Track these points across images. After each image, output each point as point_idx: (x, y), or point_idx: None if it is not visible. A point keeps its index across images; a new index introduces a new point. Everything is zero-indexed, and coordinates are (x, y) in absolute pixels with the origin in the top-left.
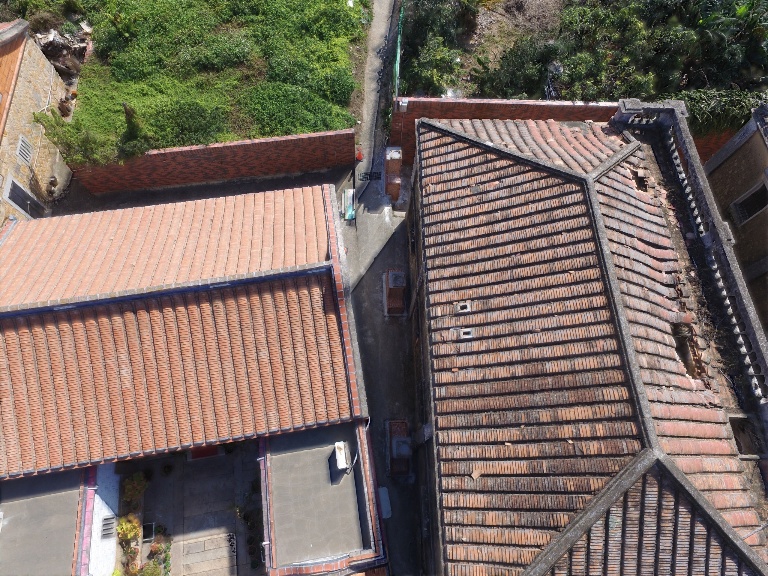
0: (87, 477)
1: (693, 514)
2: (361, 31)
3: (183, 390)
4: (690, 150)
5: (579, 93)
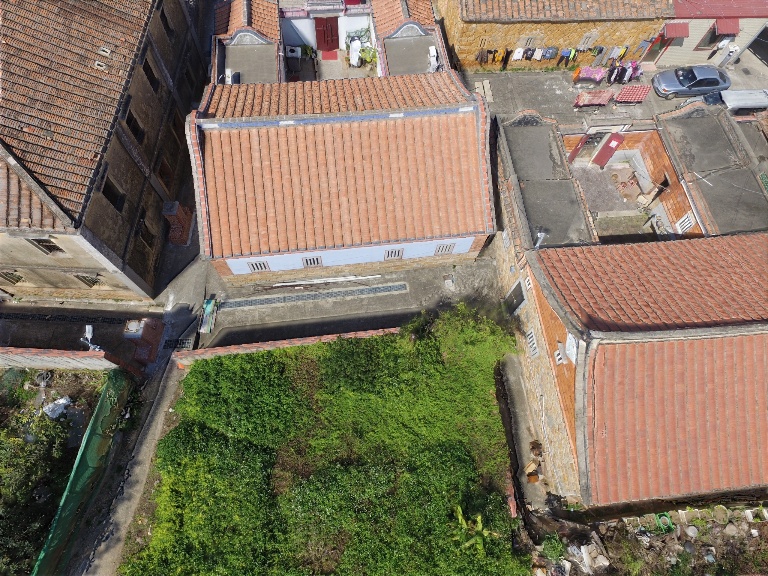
0: None
1: None
2: (125, 575)
3: None
4: None
5: None
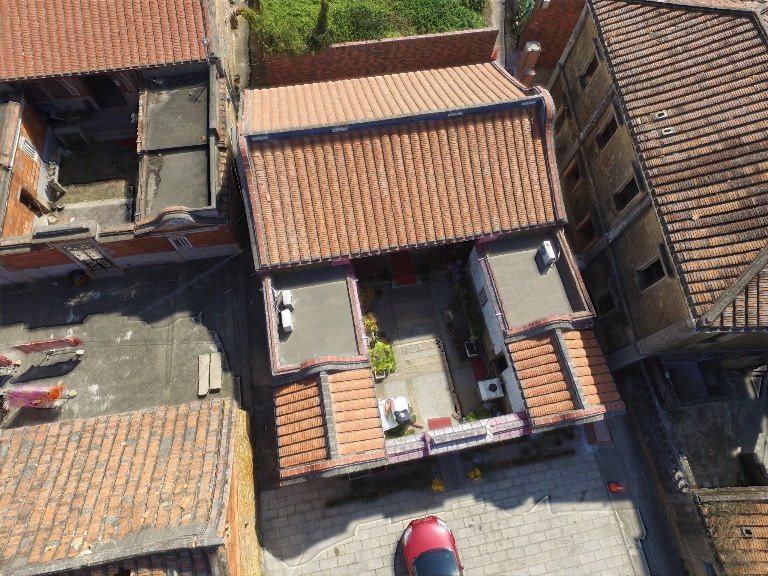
0: (349, 272)
1: None
2: None
3: (427, 199)
4: None
5: None
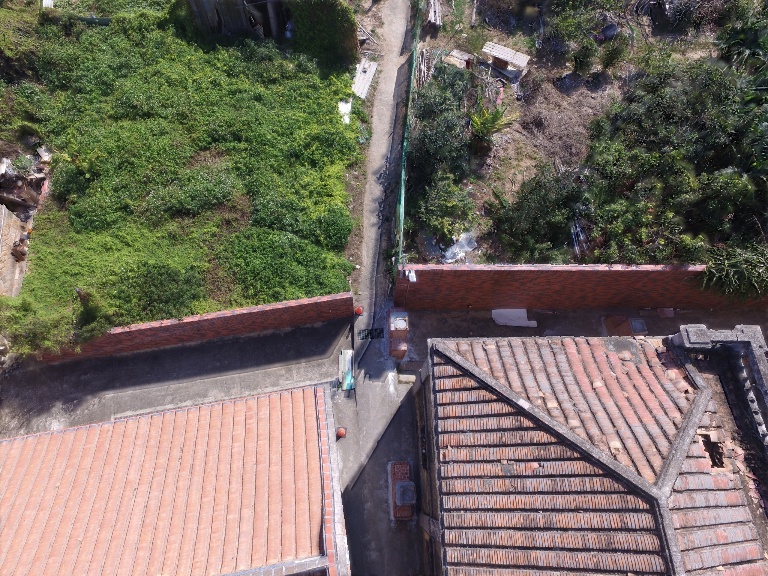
0: None
1: None
2: (359, 153)
3: None
4: None
5: (616, 258)
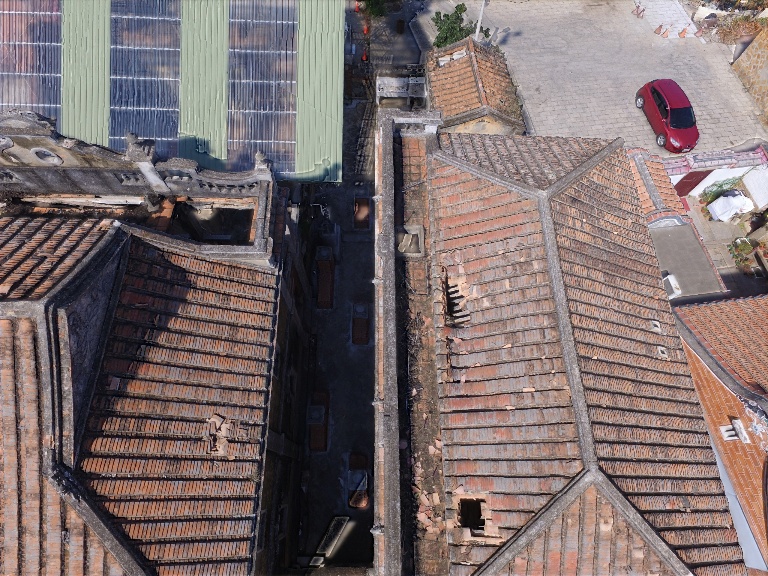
0: None
1: None
2: None
3: None
4: (399, 571)
5: None
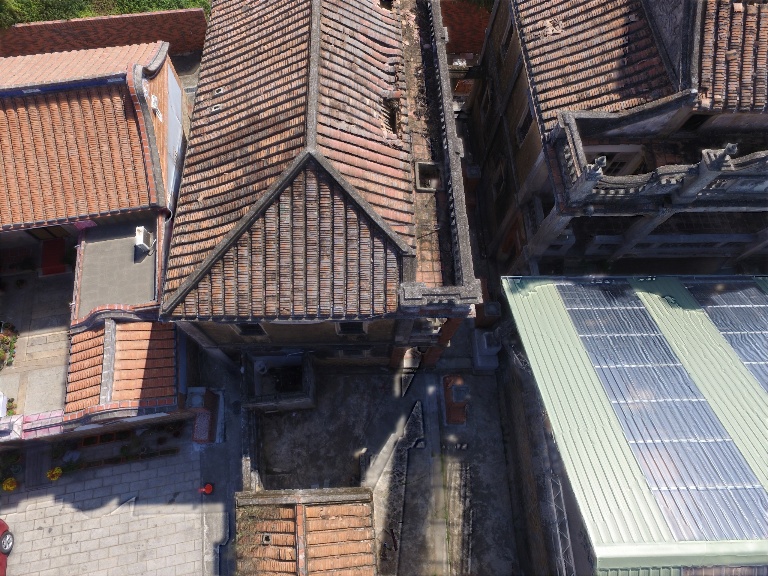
0: None
1: (346, 203)
2: None
3: (3, 180)
4: None
5: None
